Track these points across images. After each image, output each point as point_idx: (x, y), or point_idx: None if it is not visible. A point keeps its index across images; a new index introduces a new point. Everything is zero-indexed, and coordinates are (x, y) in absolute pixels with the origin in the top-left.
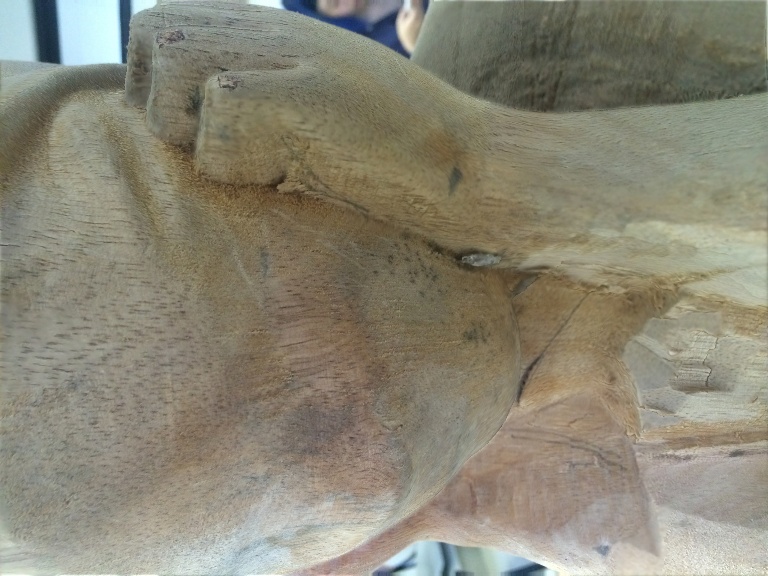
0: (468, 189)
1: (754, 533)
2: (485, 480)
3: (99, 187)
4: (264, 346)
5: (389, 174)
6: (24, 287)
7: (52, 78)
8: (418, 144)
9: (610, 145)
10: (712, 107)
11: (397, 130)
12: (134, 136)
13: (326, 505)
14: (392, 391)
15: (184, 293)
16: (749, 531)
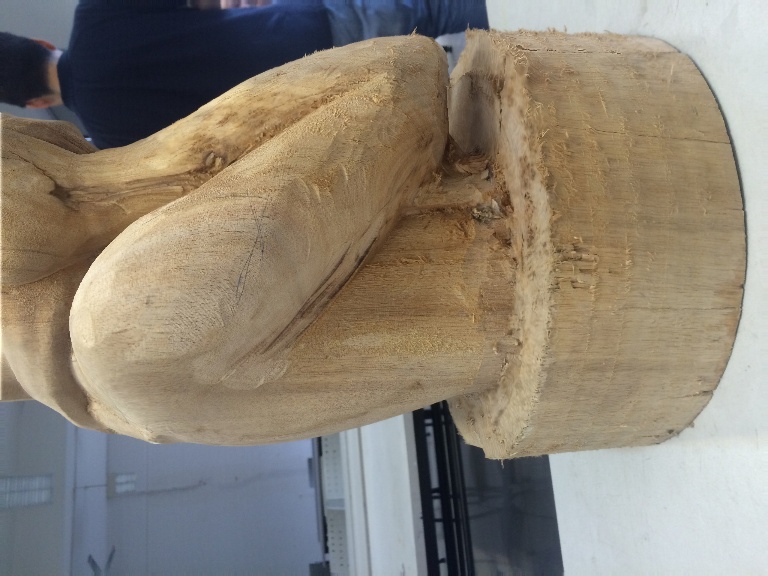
0: None
1: None
2: None
3: None
4: None
5: None
6: None
7: None
8: None
9: None
10: None
11: None
12: None
13: None
14: None
15: None
16: None
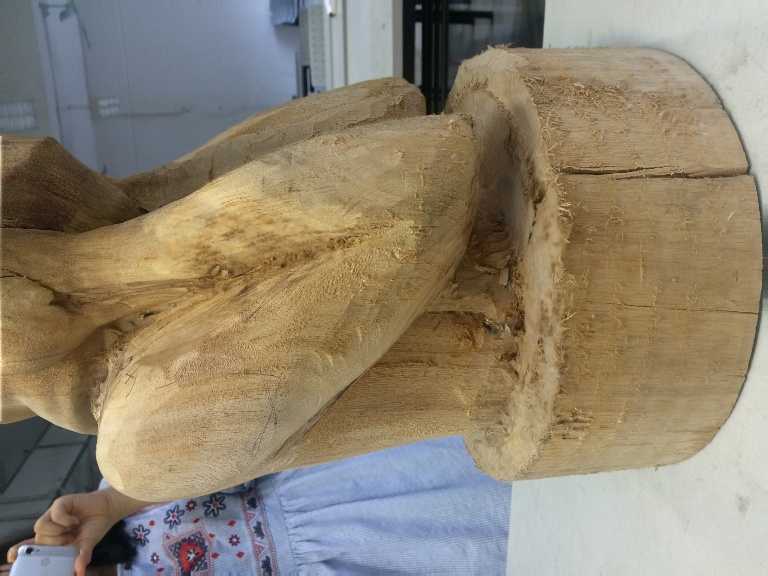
0: None
1: None
2: None
3: None
4: None
5: None
6: None
7: None
8: None
9: None
10: None
11: None
12: None
13: None
14: None
15: None
16: None
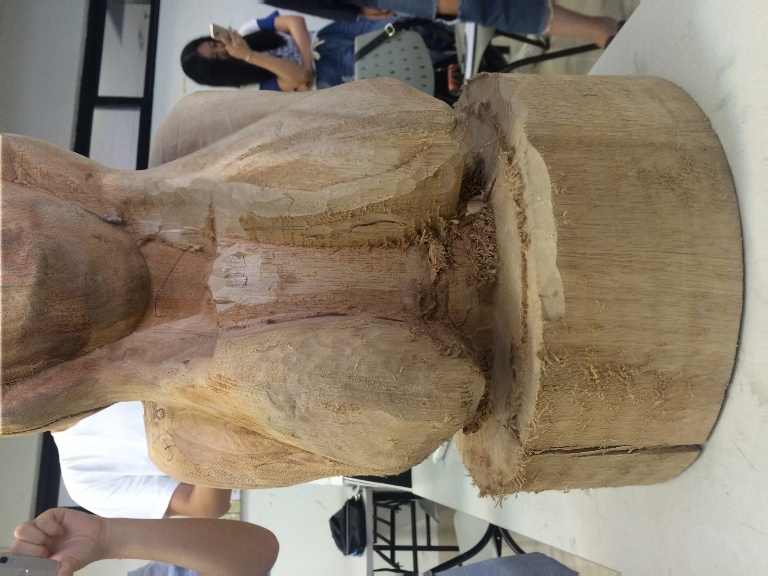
0: (95, 181)
1: None
2: None
3: None
4: None
5: (56, 169)
6: None
7: None
8: (70, 162)
9: None
10: None
11: (61, 156)
12: None
13: (5, 273)
14: (42, 232)
15: None
16: None
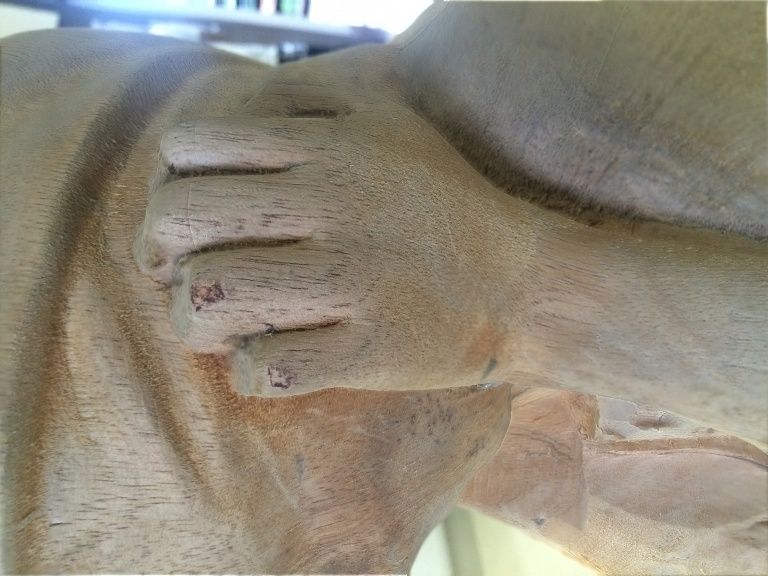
0: (499, 370)
1: (658, 525)
2: None
3: (140, 446)
4: (298, 536)
5: None
6: (83, 560)
7: (50, 250)
8: (461, 360)
9: (647, 328)
10: (758, 299)
11: (444, 359)
12: (160, 345)
13: None
14: (403, 539)
15: (231, 532)
16: (655, 523)
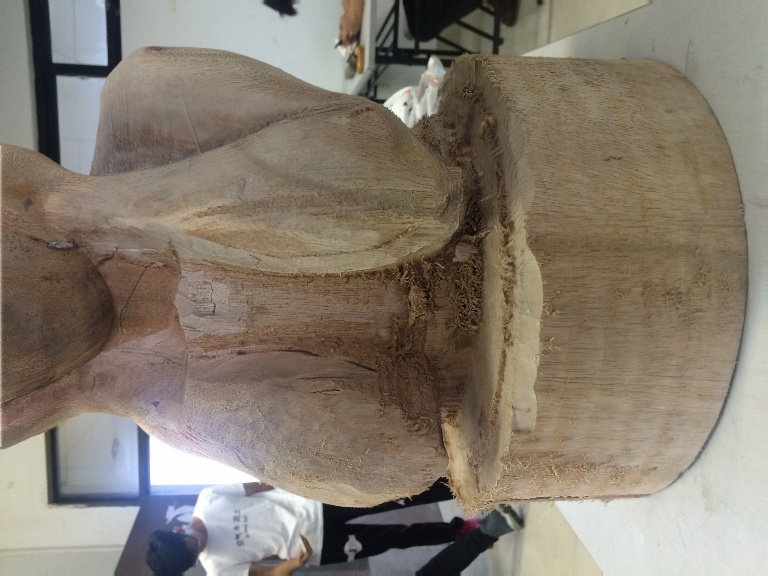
0: (36, 208)
1: (227, 386)
2: (103, 374)
3: None
4: None
5: None
6: None
7: None
8: (4, 188)
9: None
10: None
11: None
12: None
13: None
14: None
15: None
16: (225, 385)
